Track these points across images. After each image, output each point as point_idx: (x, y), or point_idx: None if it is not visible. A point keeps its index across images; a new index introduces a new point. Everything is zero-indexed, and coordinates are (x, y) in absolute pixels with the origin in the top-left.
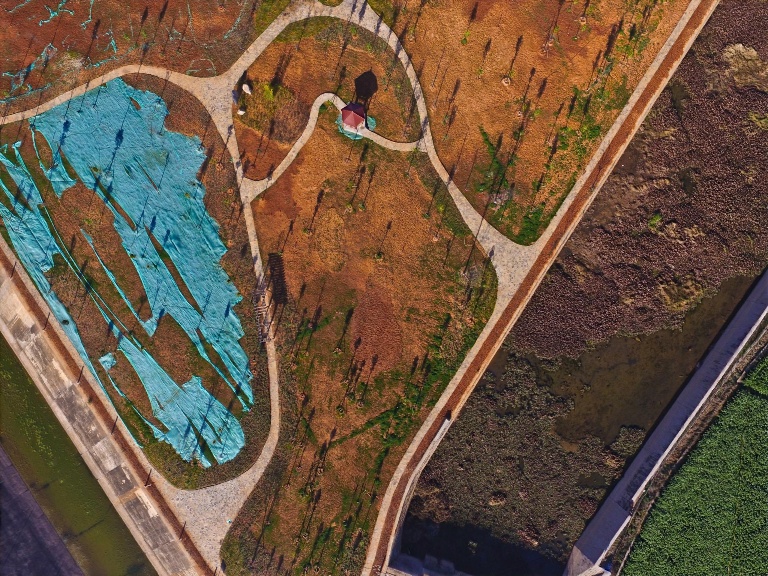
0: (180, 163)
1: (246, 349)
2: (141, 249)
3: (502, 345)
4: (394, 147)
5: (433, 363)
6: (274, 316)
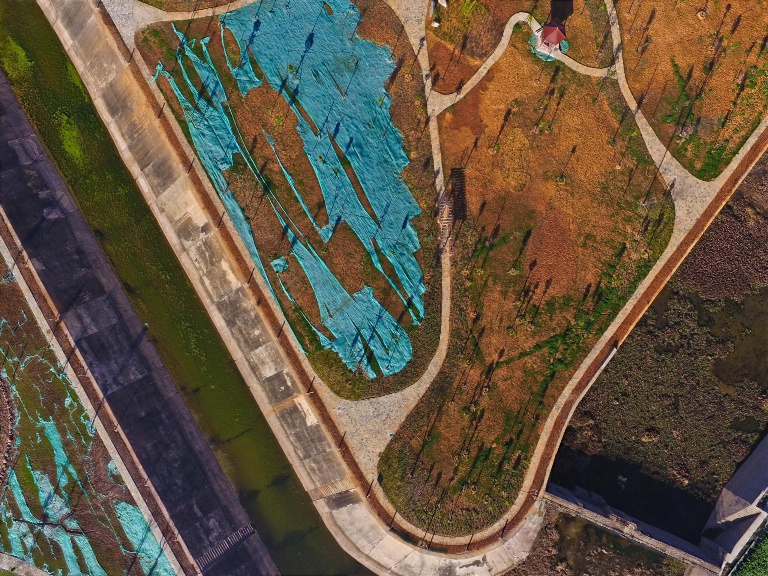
0: (369, 71)
1: (421, 262)
2: (322, 154)
3: None
4: (585, 71)
5: (605, 291)
6: (452, 231)
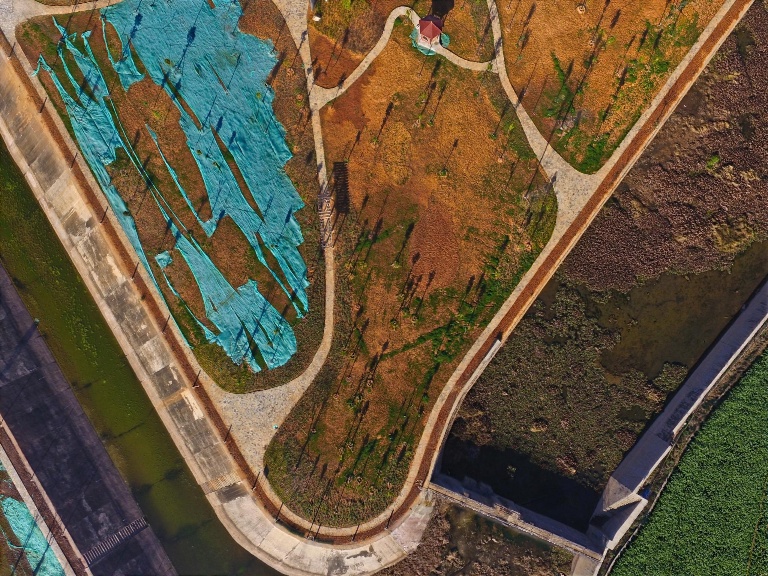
0: (251, 65)
1: (304, 256)
2: (205, 149)
3: (554, 274)
4: (466, 65)
5: (488, 284)
6: (335, 225)
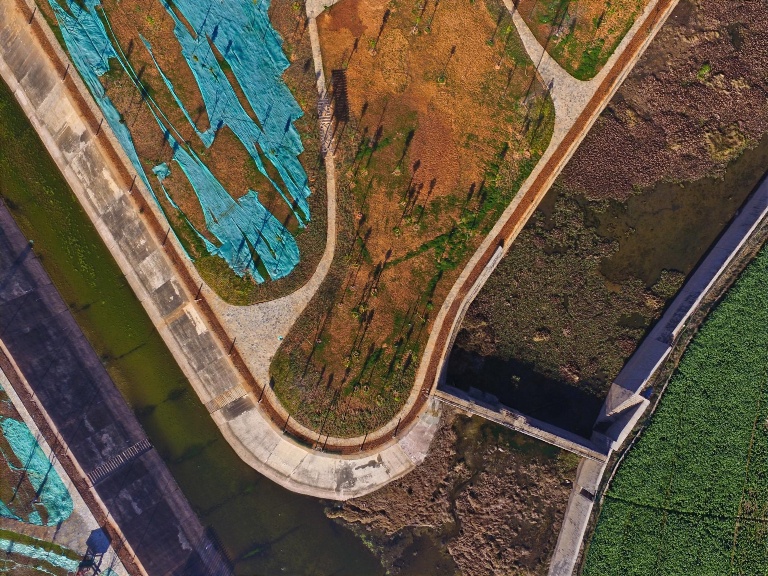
0: None
1: (305, 165)
2: (201, 58)
3: (553, 185)
4: None
5: (489, 191)
6: (335, 133)
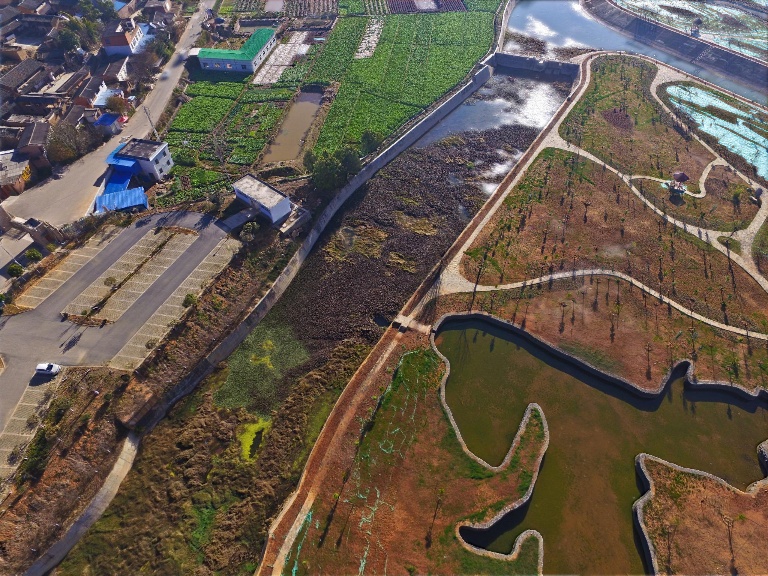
0: None
1: None
2: (767, 144)
3: None
4: (645, 176)
5: None
6: None
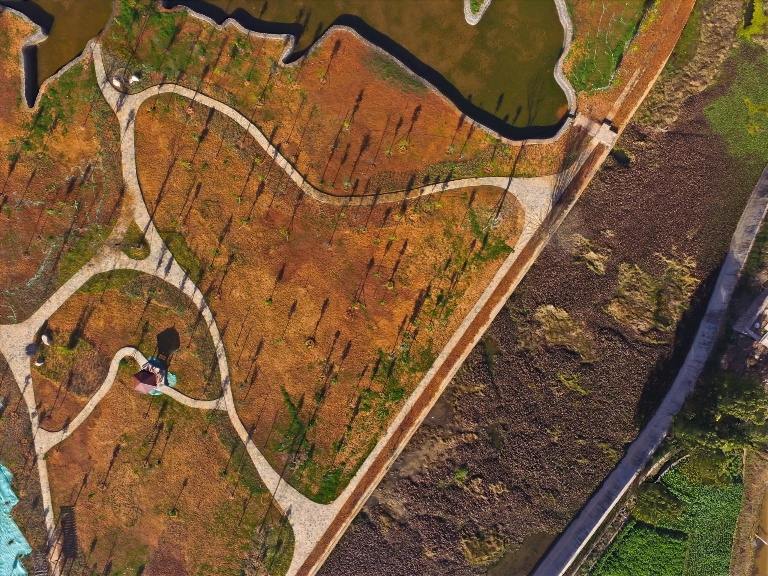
0: None
1: None
2: None
3: None
4: (193, 405)
5: None
6: (63, 570)
